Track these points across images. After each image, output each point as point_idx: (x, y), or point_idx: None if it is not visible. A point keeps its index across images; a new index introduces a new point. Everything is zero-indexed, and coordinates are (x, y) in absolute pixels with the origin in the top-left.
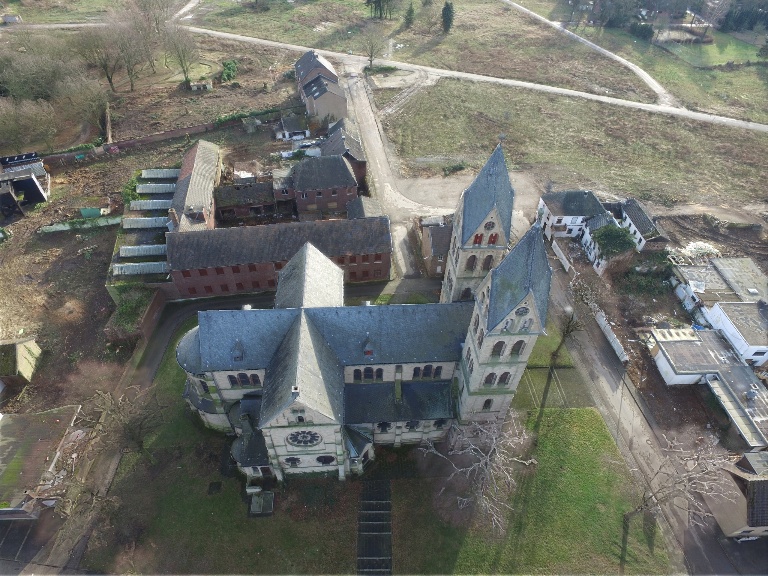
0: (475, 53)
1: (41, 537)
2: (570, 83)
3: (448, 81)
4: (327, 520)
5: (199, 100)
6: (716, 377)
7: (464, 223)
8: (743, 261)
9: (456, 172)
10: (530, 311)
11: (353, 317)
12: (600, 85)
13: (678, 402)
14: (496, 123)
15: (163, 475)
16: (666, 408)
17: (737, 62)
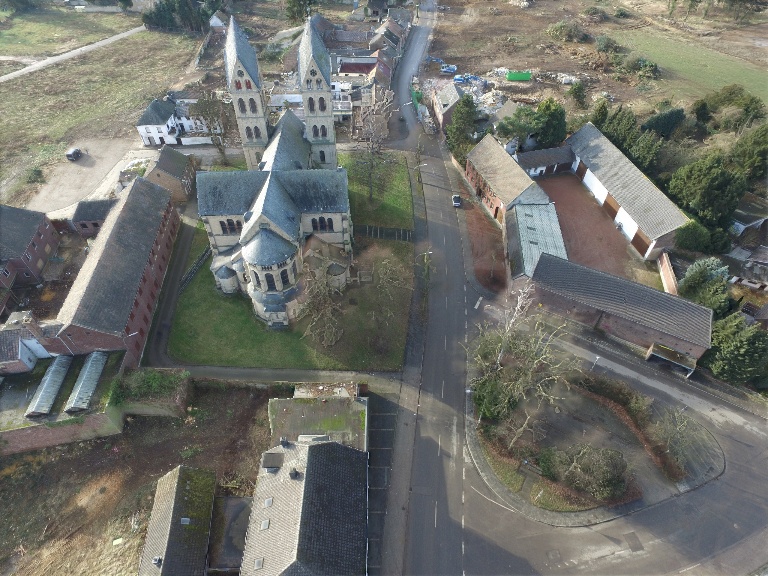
0: None
1: (381, 404)
2: None
3: None
4: (377, 250)
5: None
6: None
7: (250, 75)
8: None
9: (43, 175)
10: None
11: (282, 157)
12: None
13: None
14: None
15: None
16: None
17: (2, 20)
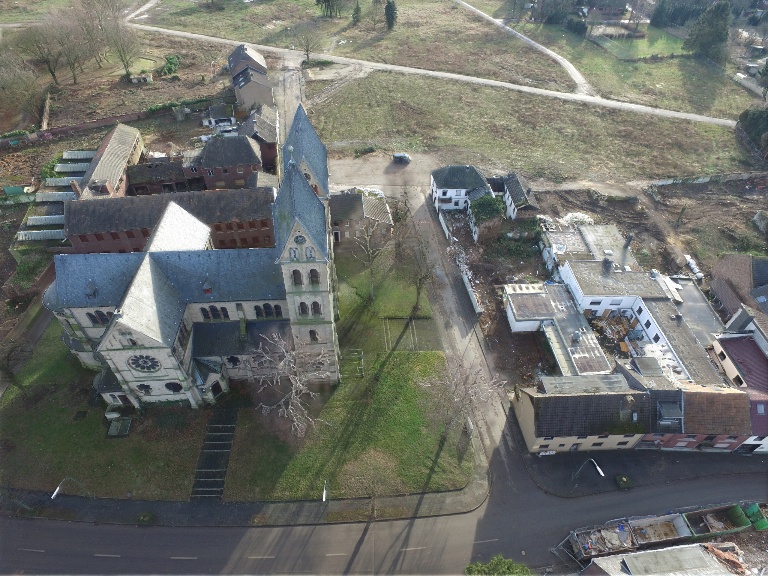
0: (413, 48)
1: None
2: (496, 74)
3: (380, 73)
4: (175, 440)
5: (138, 92)
6: (553, 323)
7: None
8: (608, 227)
9: (367, 154)
10: (307, 239)
11: (194, 260)
12: (525, 76)
13: (518, 346)
14: (416, 111)
15: (36, 406)
16: (506, 351)
17: (661, 55)
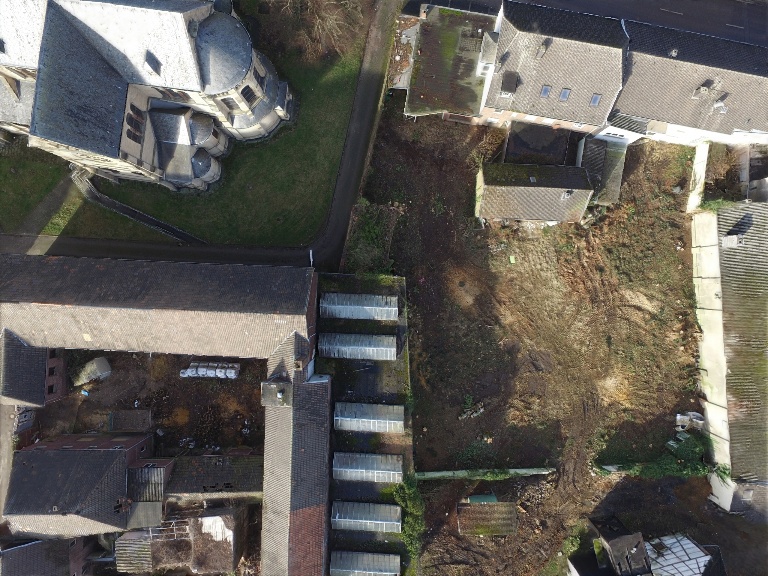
0: None
1: (417, 4)
2: None
3: None
4: None
5: None
6: None
7: None
8: None
9: None
10: None
11: None
12: None
13: None
14: None
15: None
16: None
17: None
